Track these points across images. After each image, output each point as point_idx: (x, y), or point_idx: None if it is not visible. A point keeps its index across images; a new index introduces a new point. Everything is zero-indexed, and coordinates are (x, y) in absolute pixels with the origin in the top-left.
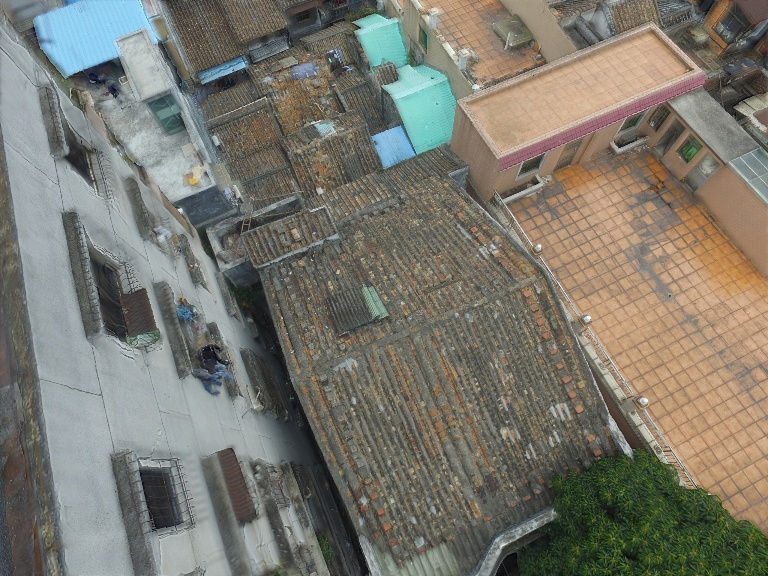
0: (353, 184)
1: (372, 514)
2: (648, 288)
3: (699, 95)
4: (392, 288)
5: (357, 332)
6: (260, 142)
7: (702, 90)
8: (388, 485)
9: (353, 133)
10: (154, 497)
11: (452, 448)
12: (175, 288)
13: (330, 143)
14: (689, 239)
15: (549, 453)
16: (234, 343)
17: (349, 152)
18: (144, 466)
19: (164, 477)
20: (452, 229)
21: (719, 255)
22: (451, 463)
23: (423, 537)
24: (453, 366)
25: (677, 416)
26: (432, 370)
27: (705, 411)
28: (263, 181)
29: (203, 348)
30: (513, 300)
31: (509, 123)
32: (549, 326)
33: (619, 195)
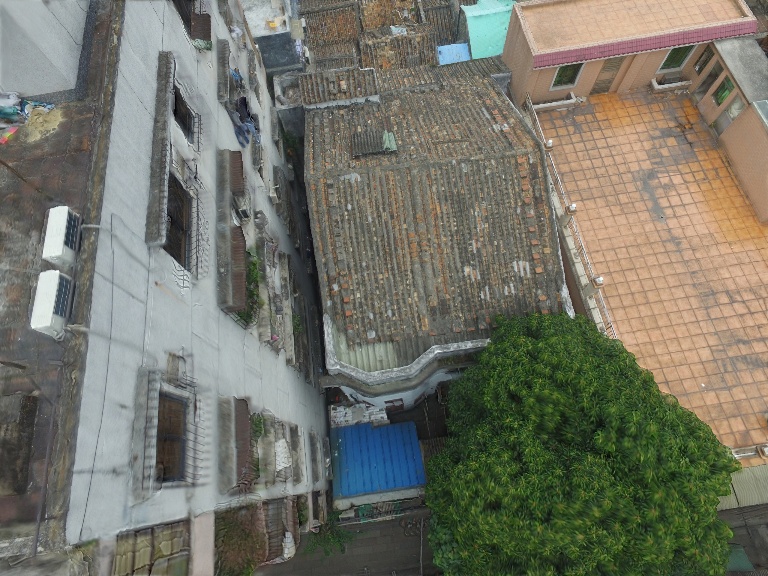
0: (406, 70)
1: (339, 300)
2: (643, 206)
3: (747, 42)
4: (408, 137)
5: (368, 158)
6: (341, 36)
7: (752, 38)
8: (358, 282)
9: (422, 37)
10: (179, 110)
11: (419, 268)
12: (234, 65)
13: (399, 42)
14: (699, 176)
15: (501, 299)
16: (270, 156)
17: (414, 54)
18: (178, 87)
19: (188, 115)
20: (476, 110)
21: (723, 195)
22: (415, 280)
23: (375, 332)
24: (439, 203)
25: (631, 311)
26: (420, 200)
27: (659, 314)
28: (333, 63)
29: (241, 98)
30: (507, 163)
31: (555, 31)
32: (532, 194)
33: (645, 126)
